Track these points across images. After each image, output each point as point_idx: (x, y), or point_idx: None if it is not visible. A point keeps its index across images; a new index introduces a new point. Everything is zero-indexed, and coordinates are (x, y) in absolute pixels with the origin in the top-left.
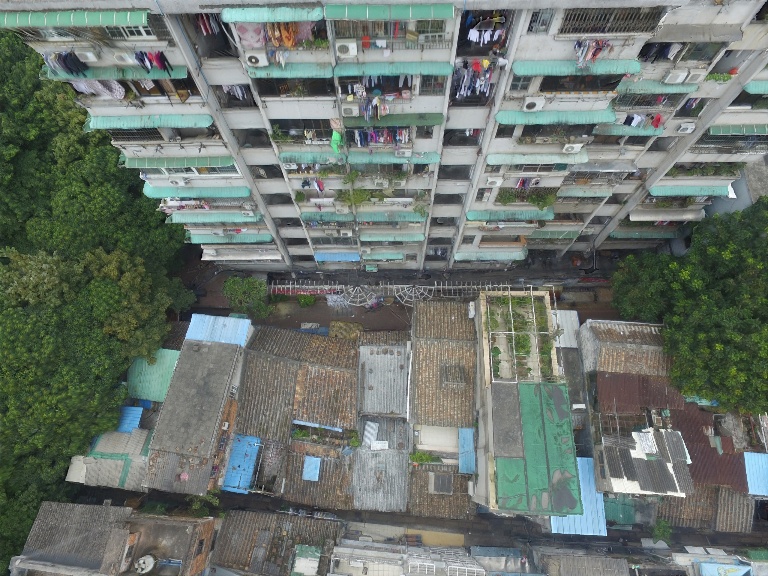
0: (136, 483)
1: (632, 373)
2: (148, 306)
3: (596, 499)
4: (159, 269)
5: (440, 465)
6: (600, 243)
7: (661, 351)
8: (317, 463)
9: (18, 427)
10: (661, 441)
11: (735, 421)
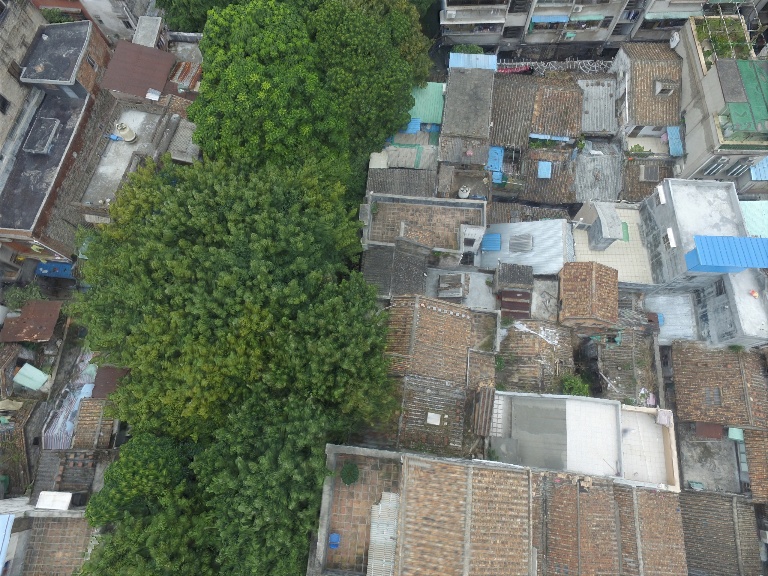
0: (428, 164)
1: None
2: (423, 39)
3: None
4: None
5: (648, 161)
6: None
7: None
8: (549, 166)
9: (361, 102)
10: None
11: None
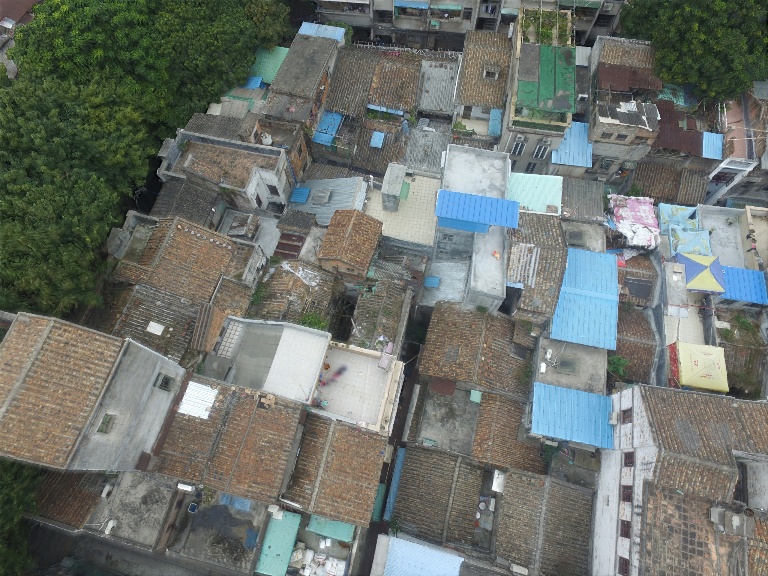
0: None
1: (626, 65)
2: (274, 5)
3: (587, 146)
4: (277, 2)
5: (473, 141)
6: (617, 22)
7: (649, 48)
8: (382, 136)
9: (189, 48)
10: (641, 107)
11: (702, 124)
